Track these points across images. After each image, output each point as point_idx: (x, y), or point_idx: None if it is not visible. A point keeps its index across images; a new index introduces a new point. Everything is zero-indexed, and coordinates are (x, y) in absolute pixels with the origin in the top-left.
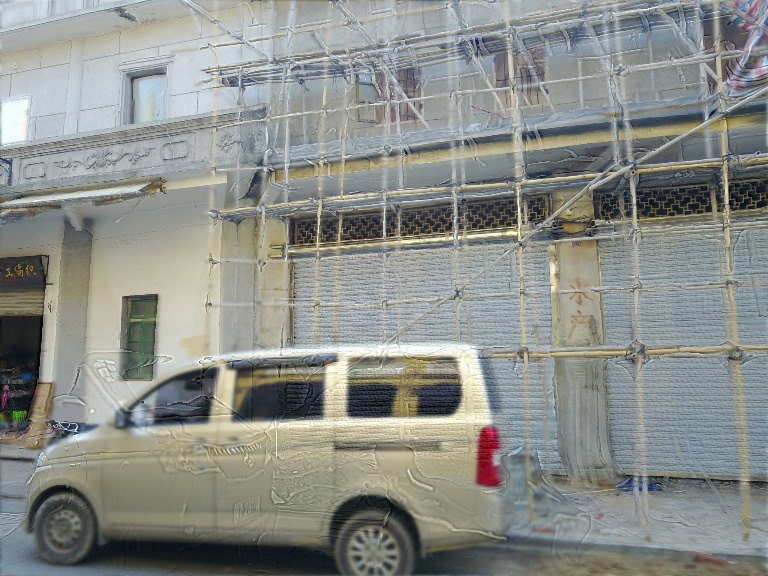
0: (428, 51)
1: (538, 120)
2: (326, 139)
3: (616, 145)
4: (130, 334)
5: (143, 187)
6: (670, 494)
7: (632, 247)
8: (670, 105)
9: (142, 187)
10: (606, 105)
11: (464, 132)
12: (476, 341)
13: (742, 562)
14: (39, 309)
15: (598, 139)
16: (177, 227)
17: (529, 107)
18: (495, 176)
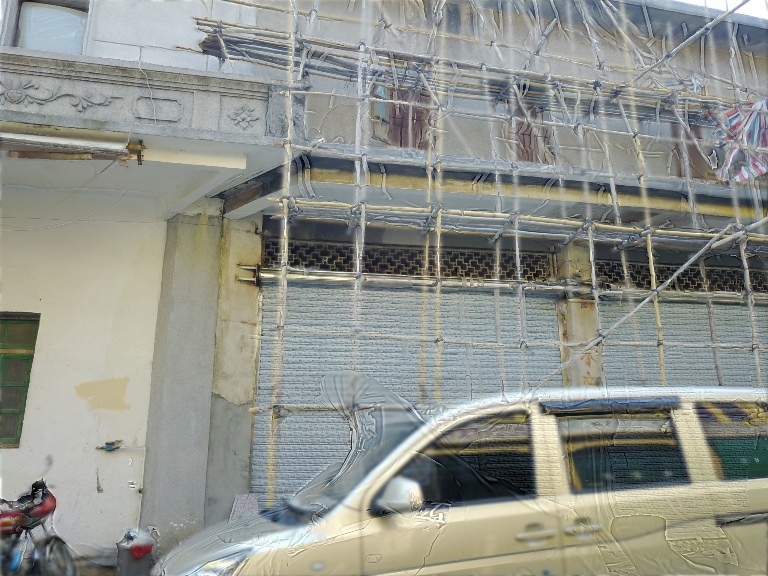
0: (470, 82)
1: None
2: None
3: (693, 213)
4: None
5: None
6: None
7: (623, 314)
8: (710, 188)
9: (125, 146)
10: None
11: (561, 170)
12: None
13: None
14: None
15: (657, 205)
16: (94, 219)
17: (543, 165)
18: None
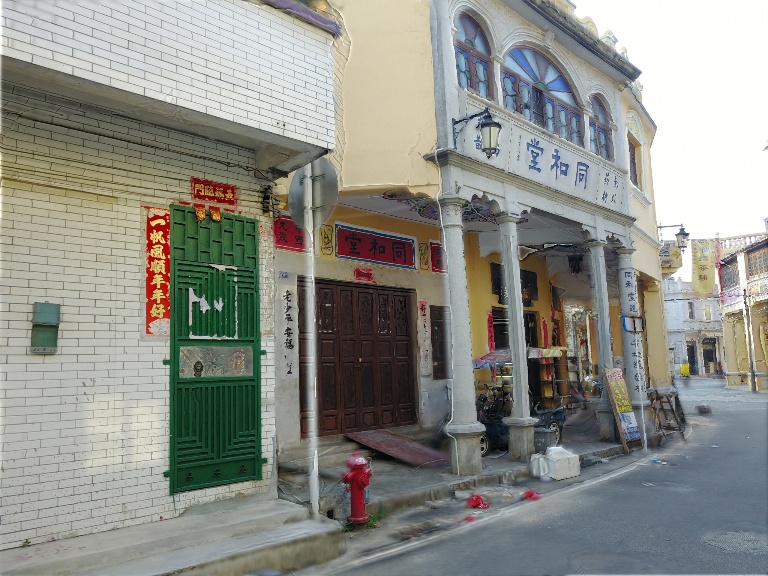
0: None
1: None
2: None
3: None
4: None
5: None
6: None
7: None
8: None
9: None
10: (767, 325)
11: None
12: None
13: None
14: (710, 348)
15: None
16: None
17: None
18: None
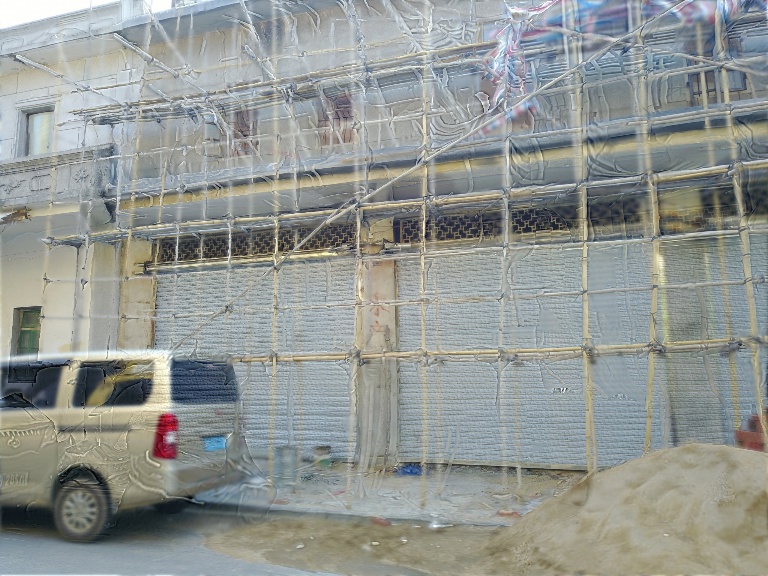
0: (252, 97)
1: (319, 161)
2: (178, 171)
3: (365, 184)
4: (21, 341)
5: (7, 215)
6: (403, 475)
7: None
8: None
9: (6, 215)
10: (398, 144)
11: (253, 172)
12: (298, 347)
13: (404, 524)
14: None
15: (364, 177)
16: (58, 247)
17: (341, 145)
18: (310, 205)
